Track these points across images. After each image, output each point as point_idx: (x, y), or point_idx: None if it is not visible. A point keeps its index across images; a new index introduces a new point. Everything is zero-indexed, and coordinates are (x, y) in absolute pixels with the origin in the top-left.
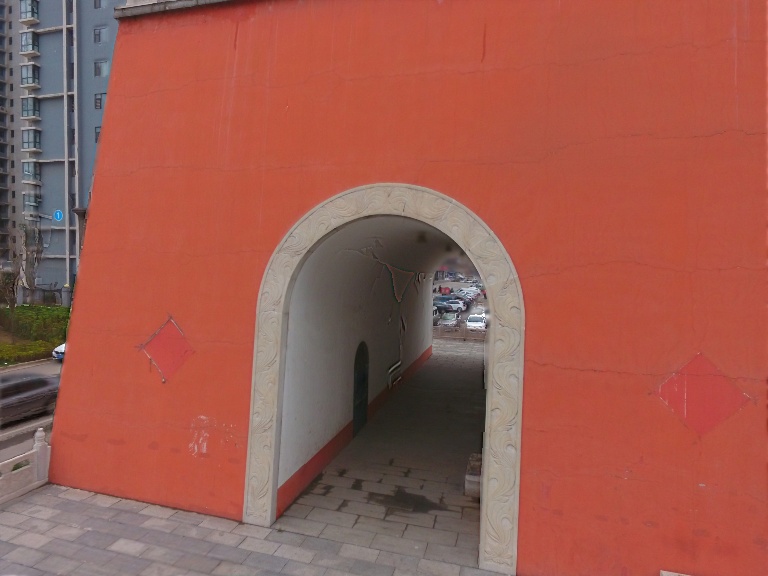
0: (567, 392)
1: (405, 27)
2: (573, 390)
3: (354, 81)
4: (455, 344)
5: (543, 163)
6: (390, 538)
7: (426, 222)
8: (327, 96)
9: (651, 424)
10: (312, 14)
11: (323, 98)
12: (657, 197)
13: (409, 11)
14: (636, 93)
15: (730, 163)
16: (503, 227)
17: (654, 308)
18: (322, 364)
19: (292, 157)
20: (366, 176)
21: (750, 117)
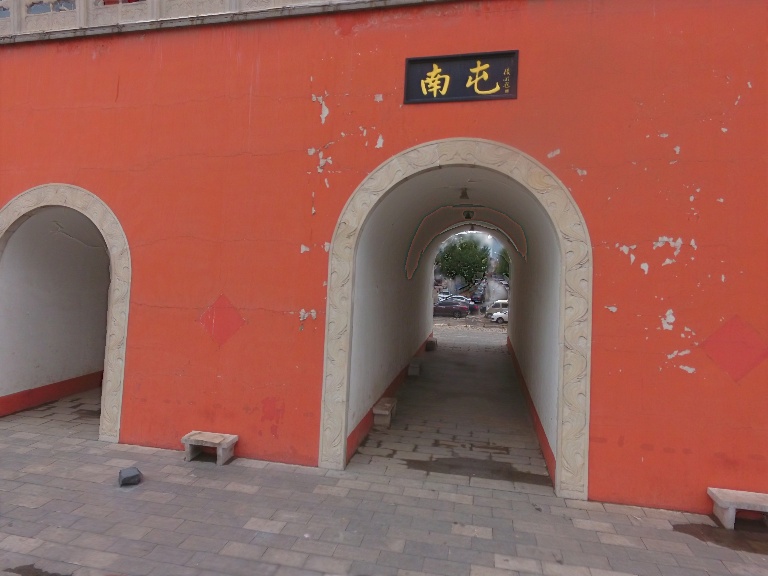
0: (154, 322)
1: (72, 75)
2: (156, 320)
3: (40, 111)
4: None
5: (146, 171)
6: (57, 429)
7: (78, 210)
8: (23, 121)
9: (195, 340)
10: (15, 62)
11: (20, 122)
12: (207, 195)
13: (75, 64)
14: (199, 127)
15: (245, 173)
16: (123, 214)
17: (201, 266)
18: (57, 318)
19: (0, 164)
20: (44, 178)
21: (256, 144)
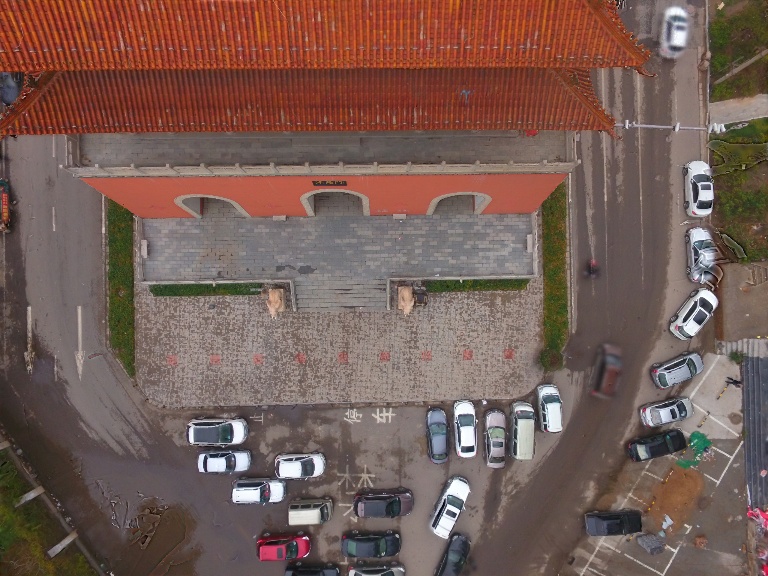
0: None
1: None
2: None
3: None
4: (465, 253)
5: None
6: None
7: None
8: None
9: None
10: None
11: None
12: None
13: None
14: None
15: None
16: None
17: None
18: None
19: None
20: None
21: None
